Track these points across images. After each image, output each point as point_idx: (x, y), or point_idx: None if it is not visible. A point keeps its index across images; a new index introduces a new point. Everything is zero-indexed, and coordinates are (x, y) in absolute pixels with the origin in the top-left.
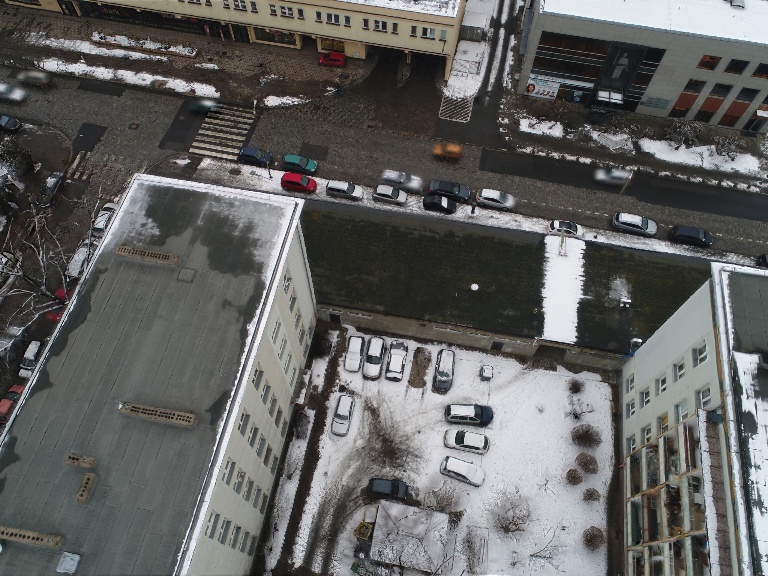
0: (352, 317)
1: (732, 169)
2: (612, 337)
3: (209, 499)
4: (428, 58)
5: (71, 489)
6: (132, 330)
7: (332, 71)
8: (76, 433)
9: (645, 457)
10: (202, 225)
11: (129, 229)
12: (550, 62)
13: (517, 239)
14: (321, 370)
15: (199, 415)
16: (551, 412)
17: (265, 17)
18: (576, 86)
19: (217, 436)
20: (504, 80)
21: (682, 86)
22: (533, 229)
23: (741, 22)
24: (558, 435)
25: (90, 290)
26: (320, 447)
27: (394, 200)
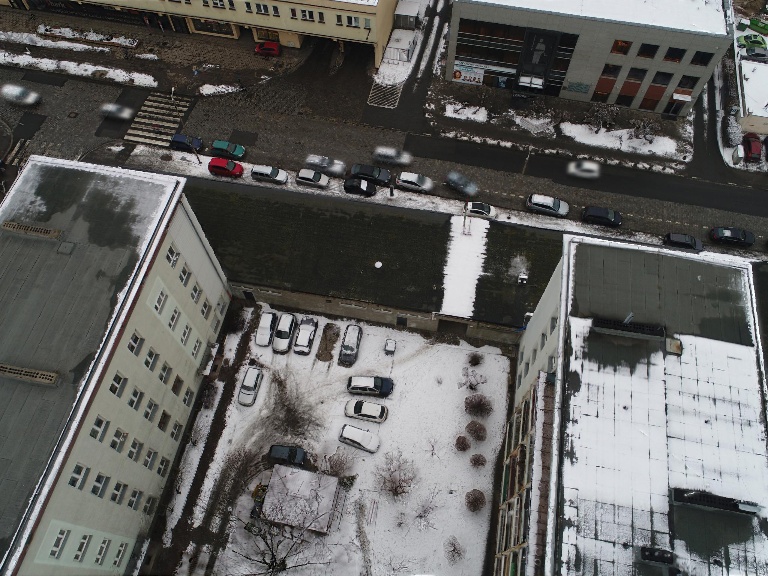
0: (263, 294)
1: (649, 151)
2: (507, 312)
3: (65, 450)
4: (362, 46)
5: None
6: (10, 298)
7: (267, 60)
8: None
9: (515, 421)
10: (86, 202)
11: (19, 206)
12: (472, 49)
13: (424, 219)
14: (233, 345)
15: (63, 375)
16: (449, 384)
17: (199, 8)
18: (500, 72)
19: (78, 394)
20: (434, 67)
21: (599, 71)
22: (449, 210)
23: (652, 7)
24: (454, 405)
25: None
26: (226, 416)
27: (315, 183)
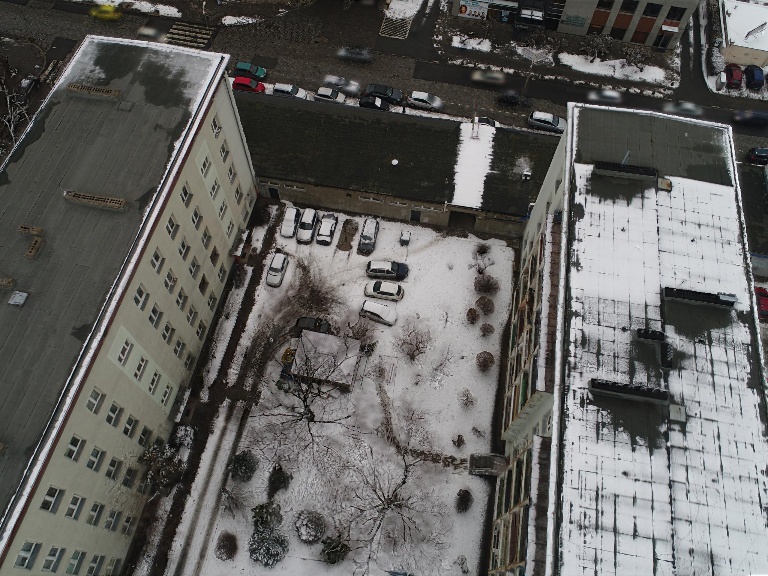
0: (288, 190)
1: (640, 79)
2: (513, 203)
3: (135, 261)
4: None
5: (23, 251)
6: (78, 144)
7: None
8: (28, 214)
9: (522, 281)
10: (141, 71)
11: (80, 74)
12: None
13: (436, 125)
14: (260, 236)
15: (130, 203)
16: (460, 269)
17: None
18: (503, 6)
19: (143, 218)
20: (441, 4)
21: (595, 3)
22: None
23: None
24: (464, 287)
25: (45, 117)
26: (256, 295)
27: (333, 100)
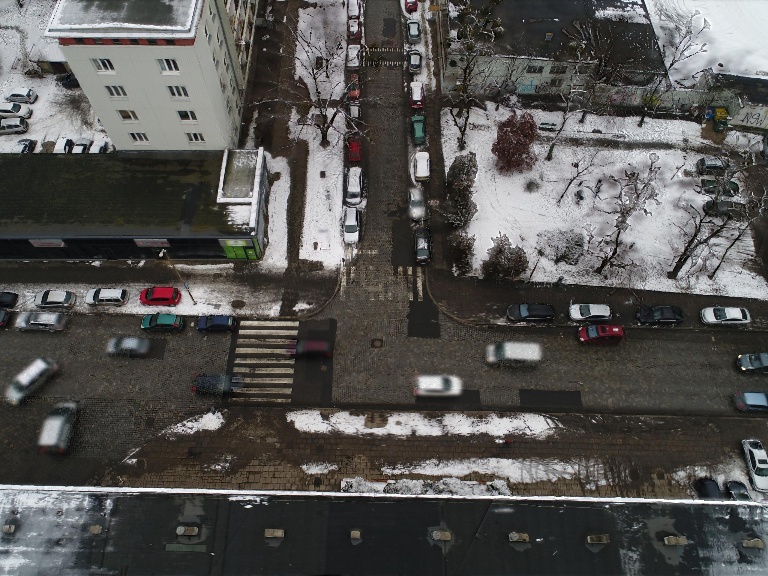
0: None
1: None
2: None
3: None
4: None
5: None
6: None
7: None
8: None
9: None
10: (124, 3)
11: None
12: None
13: None
14: None
15: None
16: None
17: None
18: None
19: None
20: None
21: None
22: None
23: None
24: None
25: None
26: None
27: None
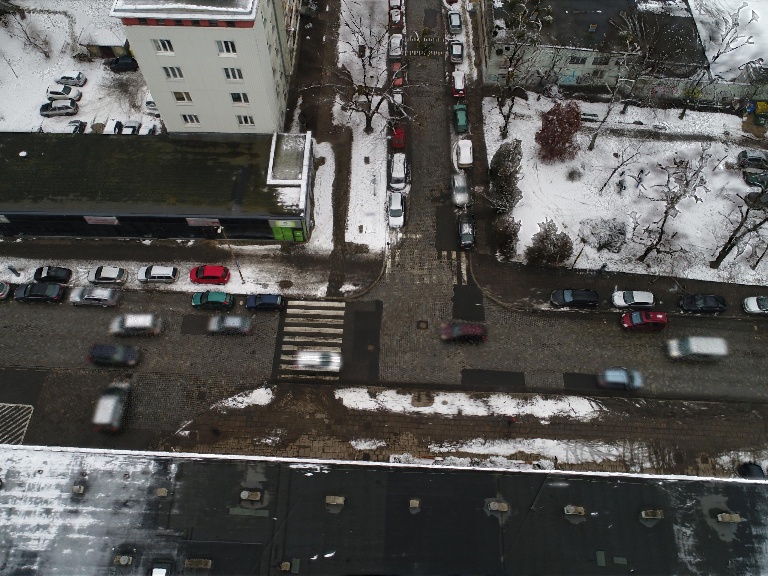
0: None
1: None
2: None
3: None
4: None
5: None
6: None
7: None
8: None
9: None
10: None
11: None
12: None
13: None
14: None
15: None
16: None
17: None
18: None
19: None
20: None
21: None
22: None
23: None
24: None
25: None
26: None
27: None
